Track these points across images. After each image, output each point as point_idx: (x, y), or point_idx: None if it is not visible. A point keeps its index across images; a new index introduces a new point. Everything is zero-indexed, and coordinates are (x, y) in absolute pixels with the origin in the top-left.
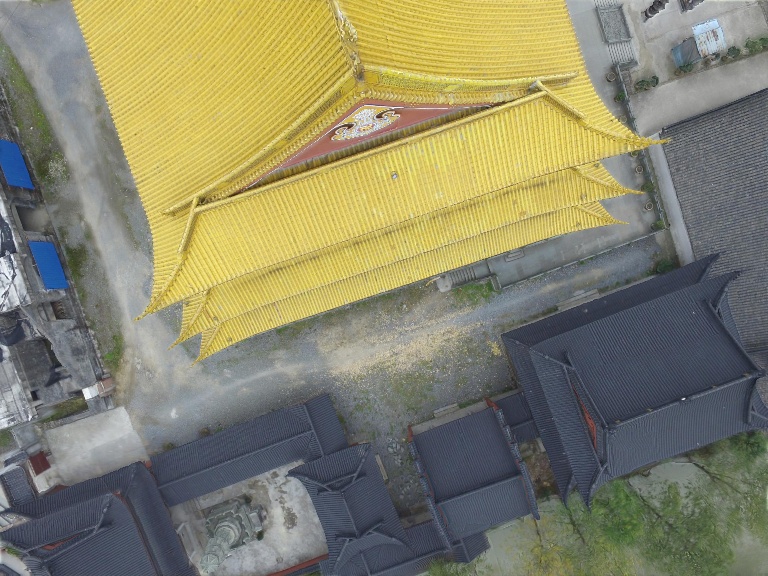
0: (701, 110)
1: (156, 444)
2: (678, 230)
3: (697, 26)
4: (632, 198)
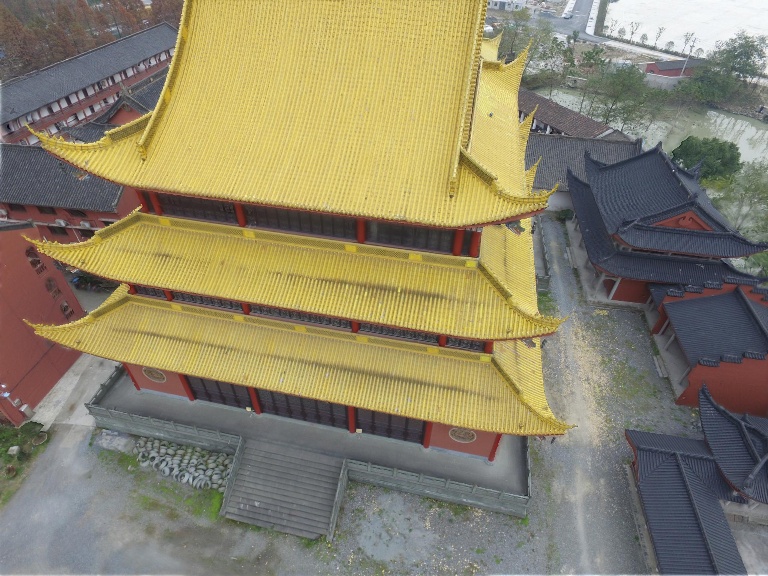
0: None
1: None
2: None
3: None
4: None
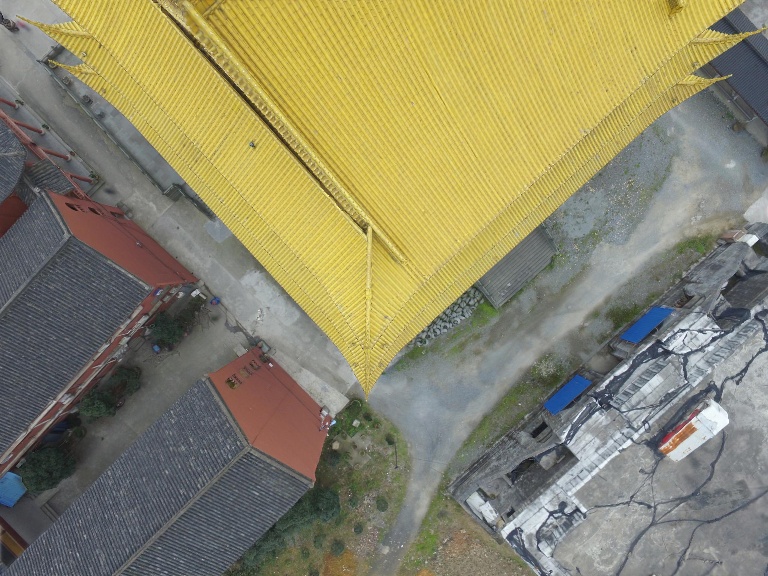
0: None
1: (767, 169)
2: None
3: None
4: None
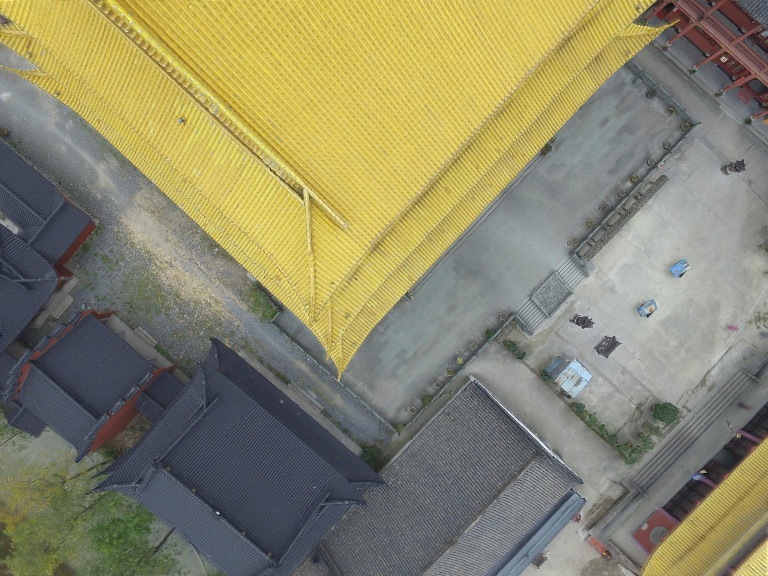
0: (523, 410)
1: None
2: None
3: (578, 362)
4: (413, 392)
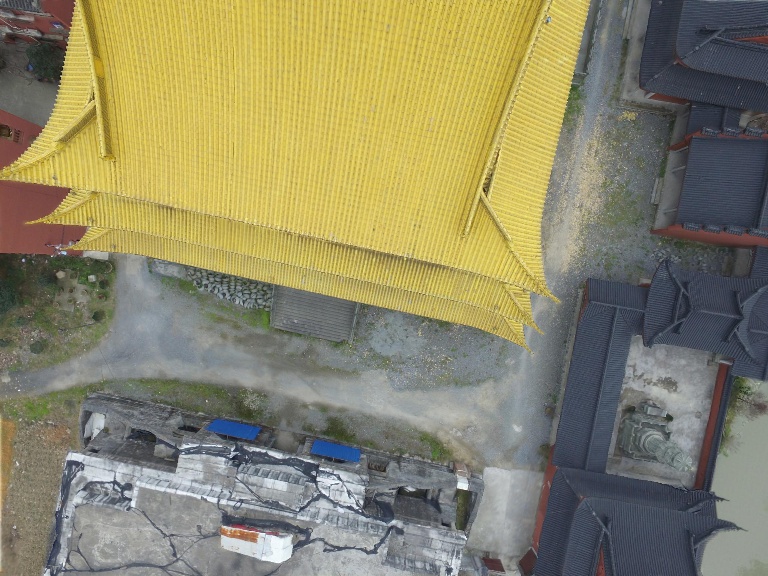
0: None
1: (534, 459)
2: None
3: None
4: None
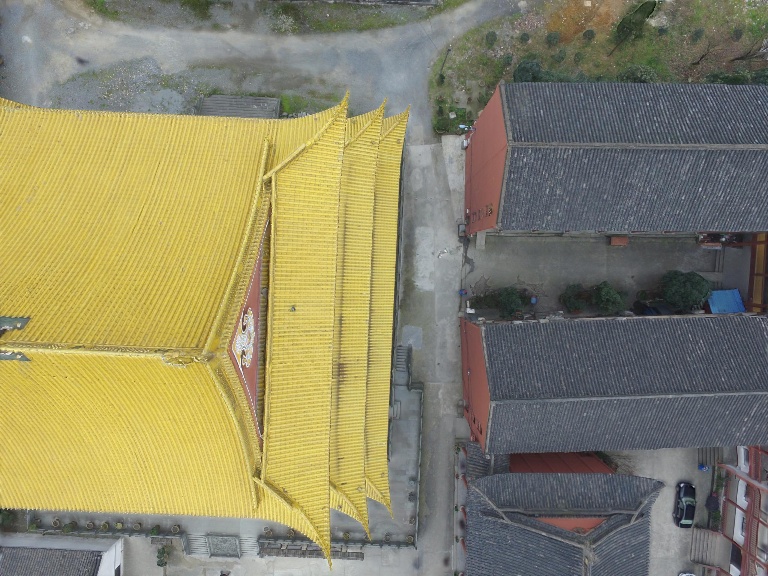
0: None
1: (4, 11)
2: (31, 540)
3: None
4: None
